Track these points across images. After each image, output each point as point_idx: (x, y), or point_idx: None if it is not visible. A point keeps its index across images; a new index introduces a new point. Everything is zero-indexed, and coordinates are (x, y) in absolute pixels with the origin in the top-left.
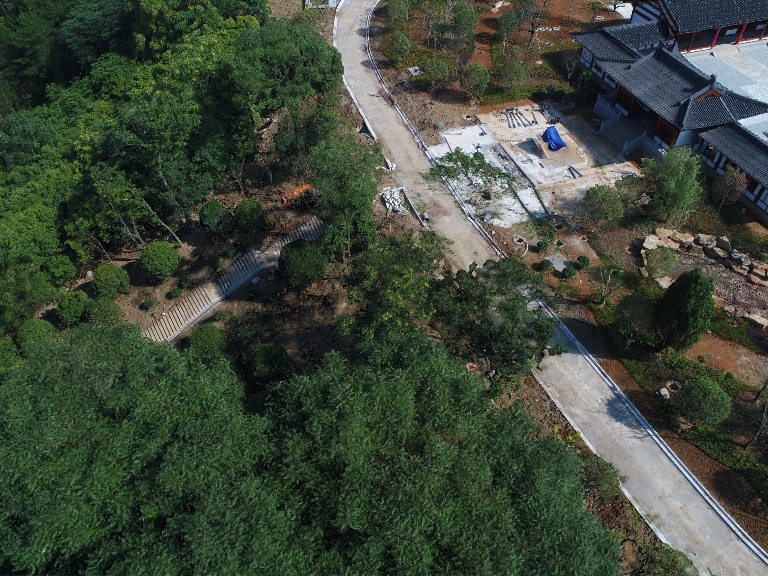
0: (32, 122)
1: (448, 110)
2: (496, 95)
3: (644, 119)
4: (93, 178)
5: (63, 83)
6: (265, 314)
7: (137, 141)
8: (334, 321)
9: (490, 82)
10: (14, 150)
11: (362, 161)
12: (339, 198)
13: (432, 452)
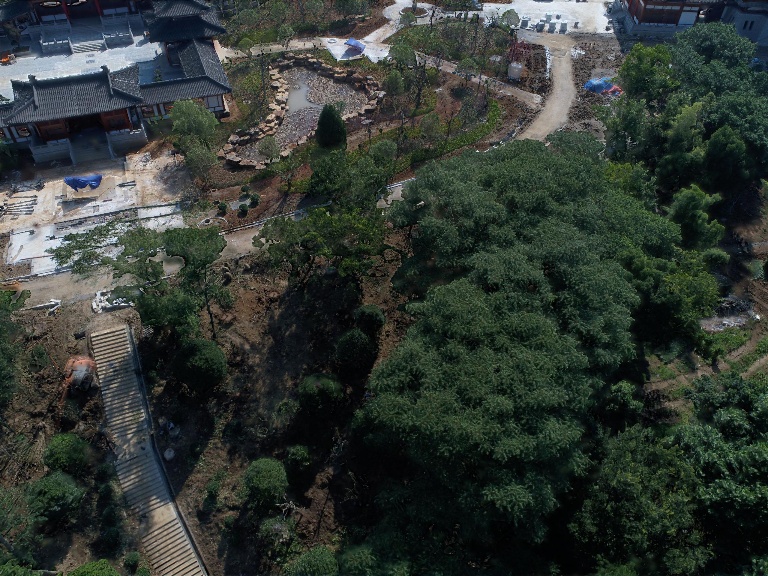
0: None
1: None
2: None
3: (77, 135)
4: None
5: None
6: (236, 424)
7: None
8: (343, 274)
9: None
10: None
11: None
12: None
13: (494, 172)
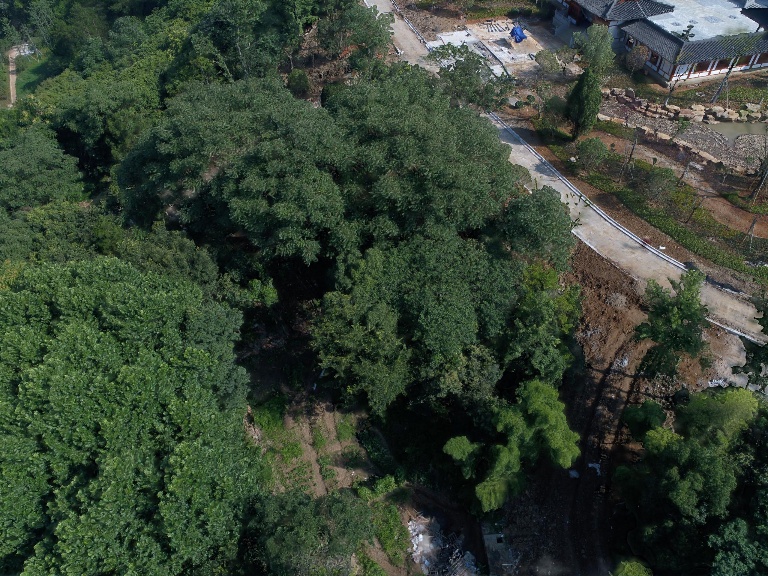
0: (134, 25)
1: (444, 21)
2: (480, 12)
3: (588, 26)
4: (193, 43)
5: (141, 18)
6: None
7: (225, 15)
8: None
9: (477, 5)
10: (119, 47)
11: (380, 20)
12: (365, 35)
13: None
